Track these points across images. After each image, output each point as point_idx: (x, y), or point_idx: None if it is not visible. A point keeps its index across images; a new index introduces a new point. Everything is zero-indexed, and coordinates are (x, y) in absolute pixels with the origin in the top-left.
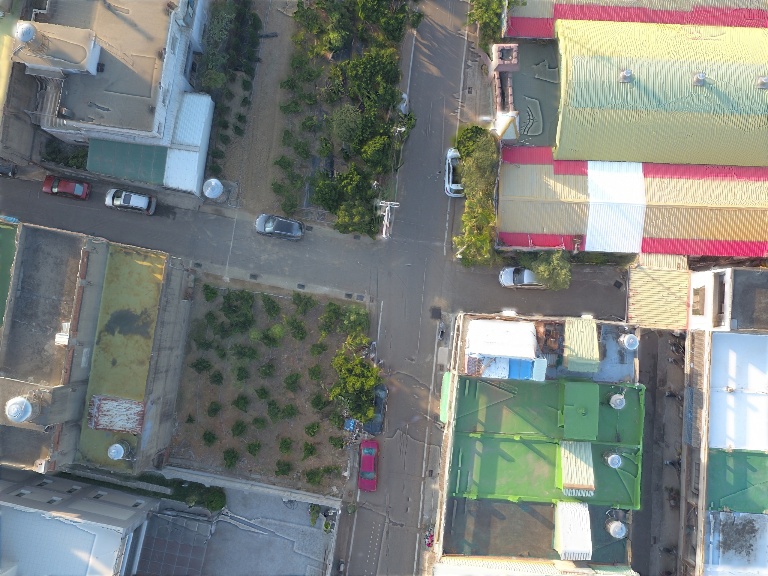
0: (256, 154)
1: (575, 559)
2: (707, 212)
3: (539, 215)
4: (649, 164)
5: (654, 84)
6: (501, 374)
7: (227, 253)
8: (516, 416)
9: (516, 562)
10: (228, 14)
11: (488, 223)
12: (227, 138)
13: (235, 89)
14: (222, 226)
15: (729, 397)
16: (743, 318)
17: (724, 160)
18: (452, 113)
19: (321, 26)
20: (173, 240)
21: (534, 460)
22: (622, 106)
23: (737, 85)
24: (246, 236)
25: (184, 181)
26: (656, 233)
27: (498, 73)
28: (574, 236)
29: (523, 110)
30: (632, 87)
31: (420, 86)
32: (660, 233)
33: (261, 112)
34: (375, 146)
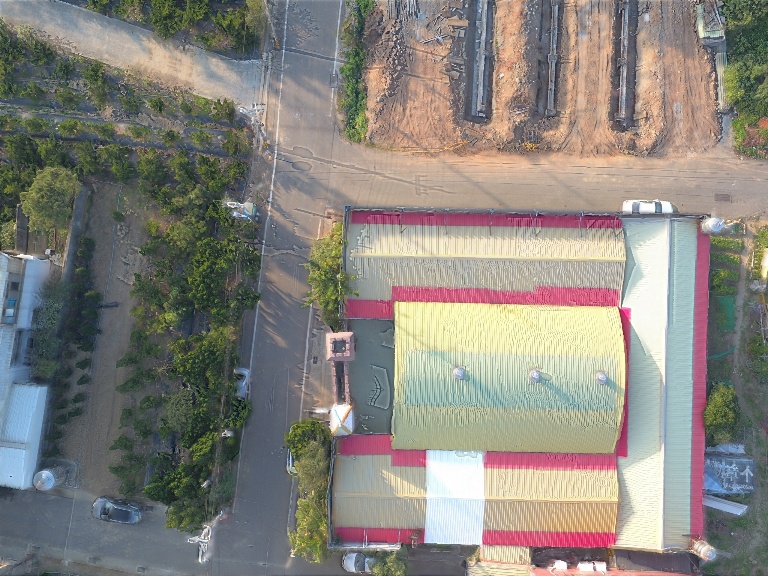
0: (95, 431)
1: None
2: (548, 505)
3: (375, 510)
4: (490, 453)
5: (491, 376)
6: None
7: (65, 536)
8: None
9: None
10: (56, 301)
11: (318, 527)
12: (62, 421)
13: (74, 363)
14: (60, 507)
15: None
16: None
17: (566, 449)
18: (296, 385)
19: (159, 300)
20: (10, 523)
21: None
22: (451, 412)
23: (577, 376)
24: (85, 517)
25: (11, 478)
26: None
27: (333, 362)
28: (411, 531)
29: (370, 380)
30: (468, 380)
31: (263, 357)
32: None
33: (100, 387)
34: (201, 449)
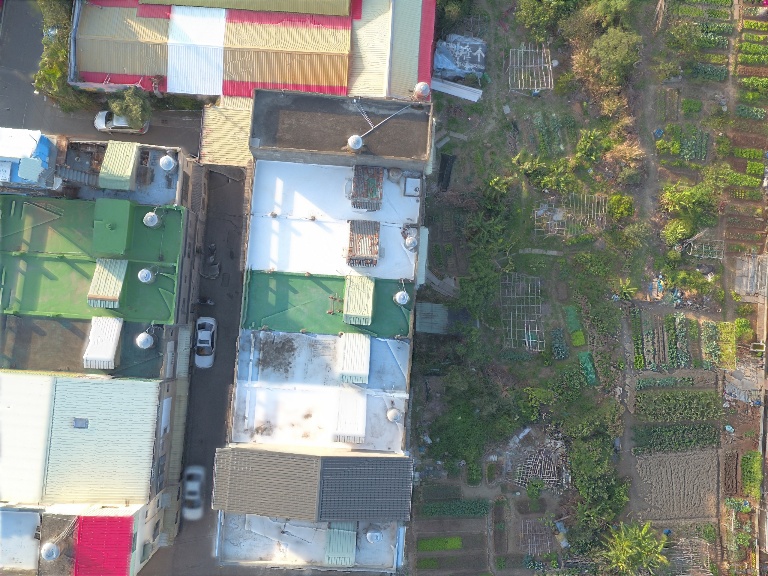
0: None
1: (98, 367)
2: (283, 56)
3: (118, 55)
4: (232, 10)
5: None
6: (2, 177)
7: None
8: (61, 236)
9: (47, 373)
10: None
11: (58, 58)
12: None
13: None
14: None
15: (274, 223)
16: (266, 138)
17: (303, 7)
18: None
19: None
20: None
21: (77, 279)
22: None
23: None
24: None
25: None
26: (235, 76)
27: None
28: (154, 76)
29: None
30: None
31: None
32: (239, 76)
33: None
34: None
